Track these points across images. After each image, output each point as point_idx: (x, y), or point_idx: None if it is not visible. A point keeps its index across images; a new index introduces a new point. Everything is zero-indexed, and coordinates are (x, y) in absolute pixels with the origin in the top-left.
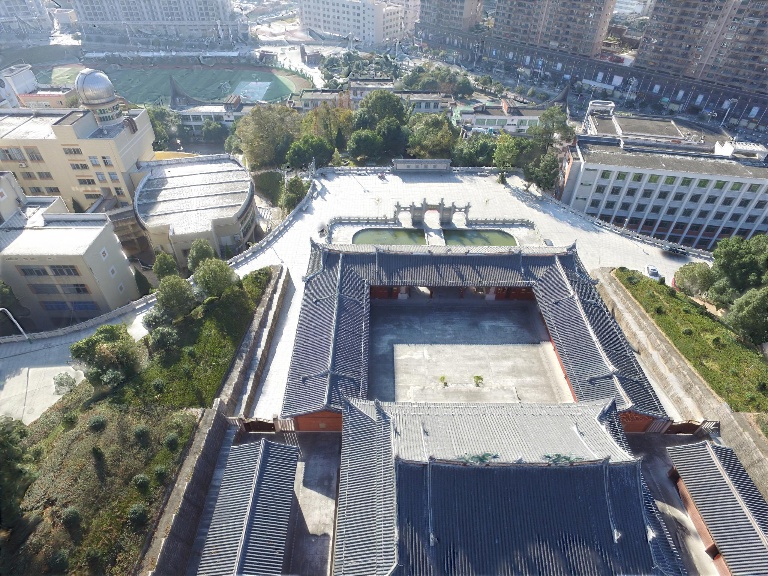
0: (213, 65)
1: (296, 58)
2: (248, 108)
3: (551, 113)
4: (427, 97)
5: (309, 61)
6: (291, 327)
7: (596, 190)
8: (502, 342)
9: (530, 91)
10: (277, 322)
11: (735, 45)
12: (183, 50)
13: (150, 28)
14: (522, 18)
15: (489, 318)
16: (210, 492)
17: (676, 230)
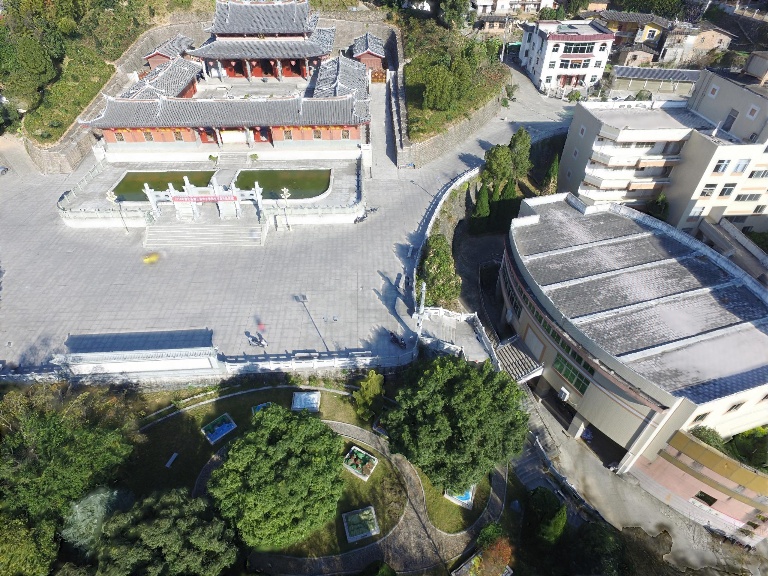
0: None
1: None
2: None
3: None
4: None
5: None
6: (380, 126)
7: None
8: None
9: None
10: (392, 128)
11: None
12: None
13: None
14: None
15: None
16: (392, 65)
17: None
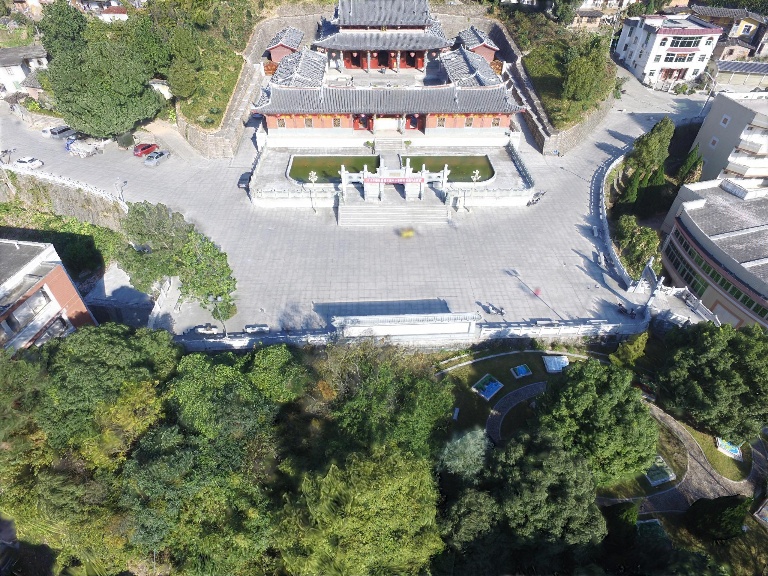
0: None
1: None
2: None
3: None
4: None
5: None
6: None
7: None
8: None
9: None
10: None
11: None
12: None
13: None
14: None
15: None
16: None
17: None
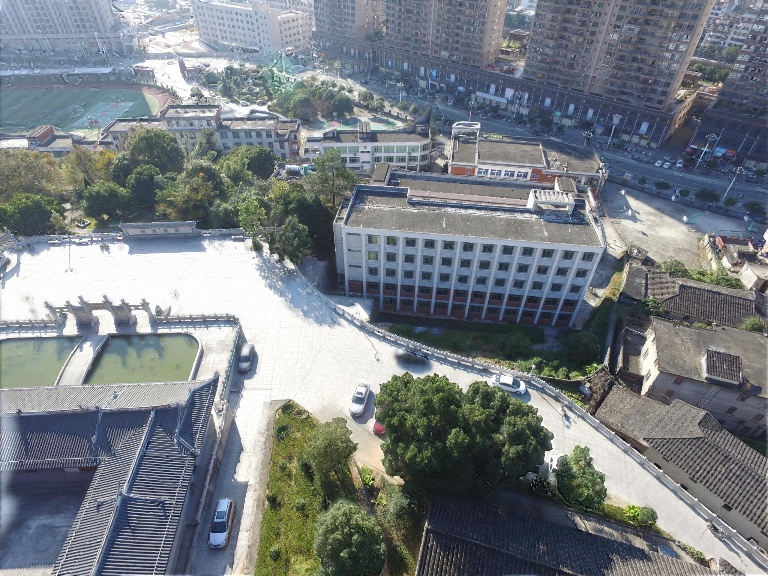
0: (79, 83)
1: (176, 73)
2: (60, 141)
3: (324, 158)
4: (260, 125)
5: (189, 76)
6: None
7: (369, 256)
8: (32, 562)
9: (412, 108)
10: None
11: (618, 55)
12: (49, 67)
13: (21, 42)
14: (412, 26)
15: (48, 510)
16: None
17: (476, 300)
